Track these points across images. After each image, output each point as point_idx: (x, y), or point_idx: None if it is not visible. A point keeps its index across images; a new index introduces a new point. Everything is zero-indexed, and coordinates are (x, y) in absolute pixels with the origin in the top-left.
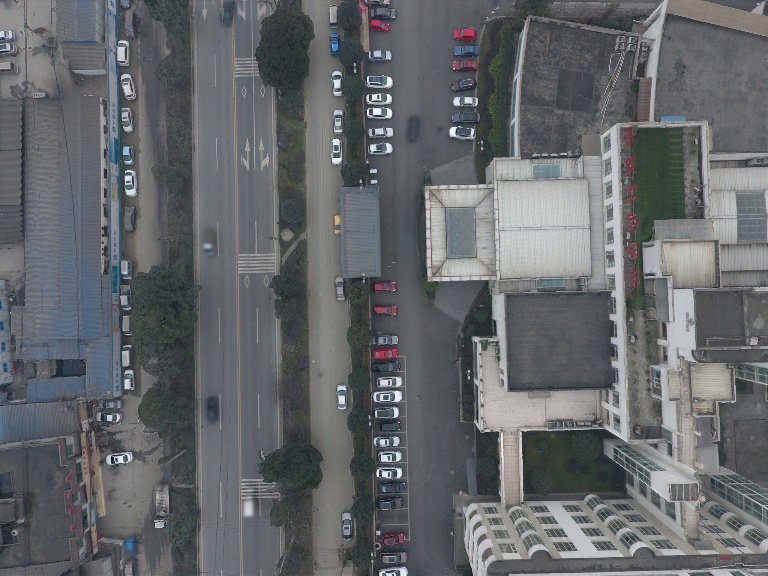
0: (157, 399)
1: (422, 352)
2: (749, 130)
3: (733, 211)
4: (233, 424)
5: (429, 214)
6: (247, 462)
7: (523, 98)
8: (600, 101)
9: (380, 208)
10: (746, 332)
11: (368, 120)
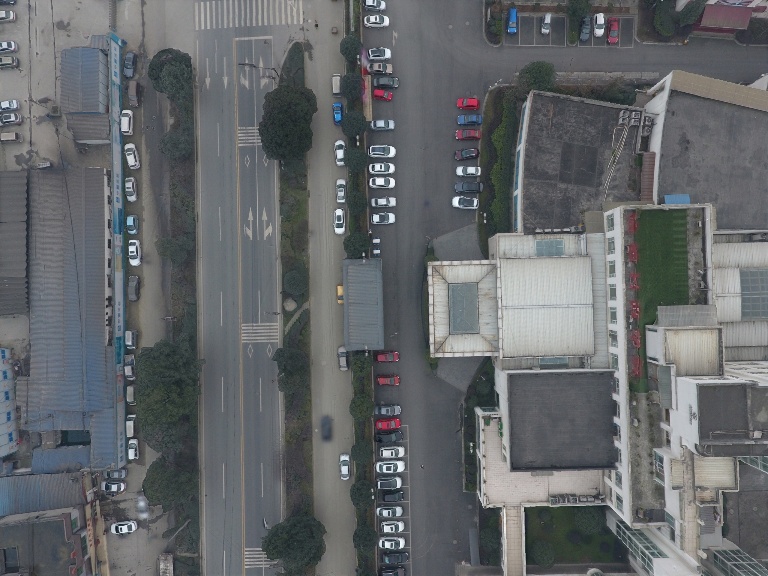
0: (161, 476)
1: (425, 422)
2: (753, 206)
3: (737, 289)
4: (237, 493)
5: (432, 290)
6: (250, 531)
7: (526, 172)
8: (603, 175)
9: (383, 277)
10: (750, 426)
11: (371, 189)
